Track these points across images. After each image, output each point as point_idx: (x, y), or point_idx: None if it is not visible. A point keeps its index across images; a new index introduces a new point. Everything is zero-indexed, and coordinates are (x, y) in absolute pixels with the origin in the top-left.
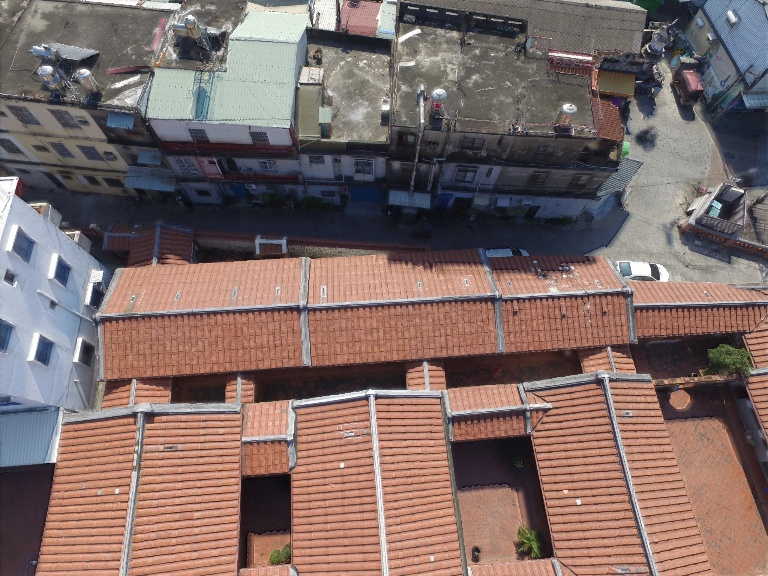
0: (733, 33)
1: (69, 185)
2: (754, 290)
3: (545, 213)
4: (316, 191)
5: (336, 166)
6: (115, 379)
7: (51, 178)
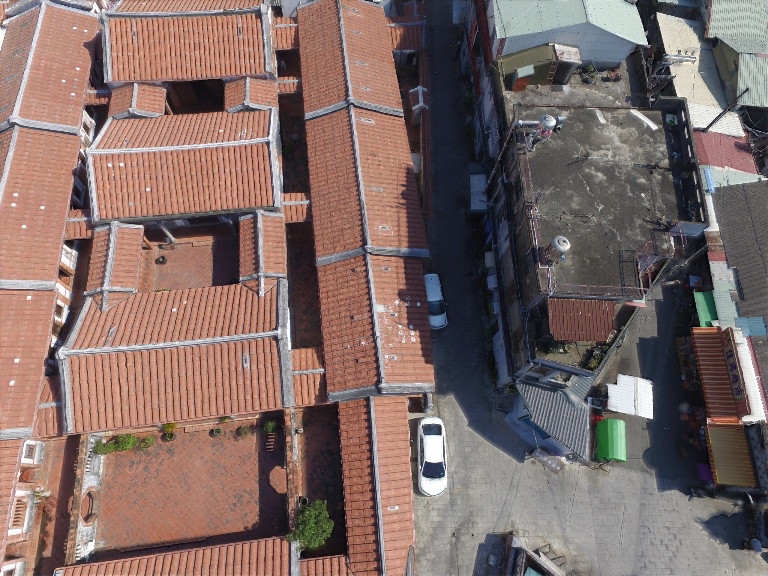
0: None
1: None
2: None
3: None
4: None
5: (495, 117)
6: (298, 15)
7: None
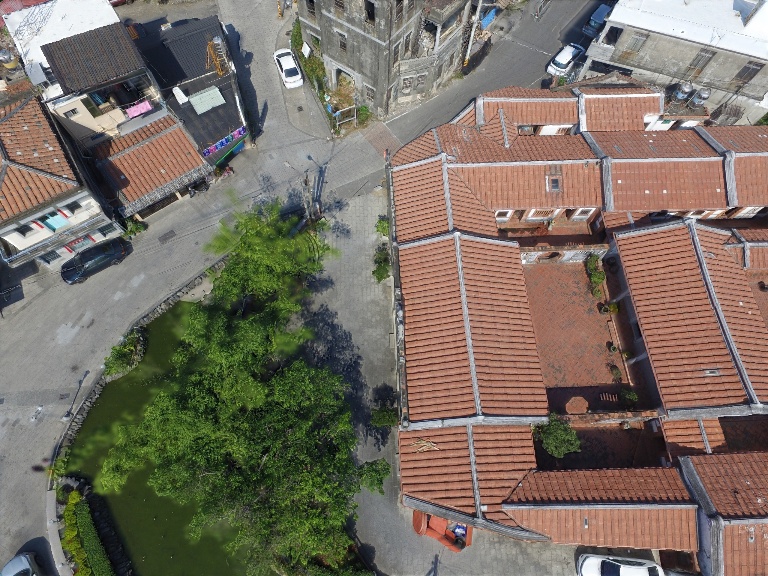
0: None
1: None
2: (523, 528)
3: None
4: None
5: None
6: None
7: None
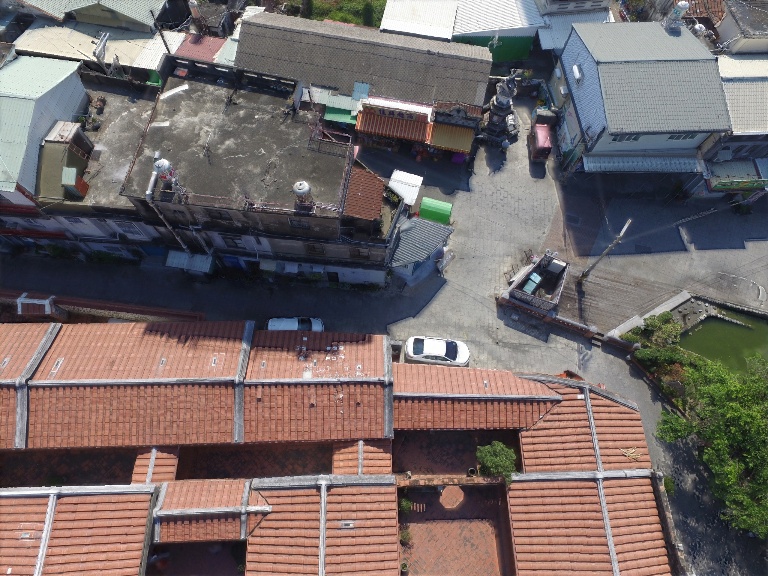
0: (579, 89)
1: None
2: (540, 382)
3: (348, 278)
4: (98, 246)
5: (104, 224)
6: None
7: None
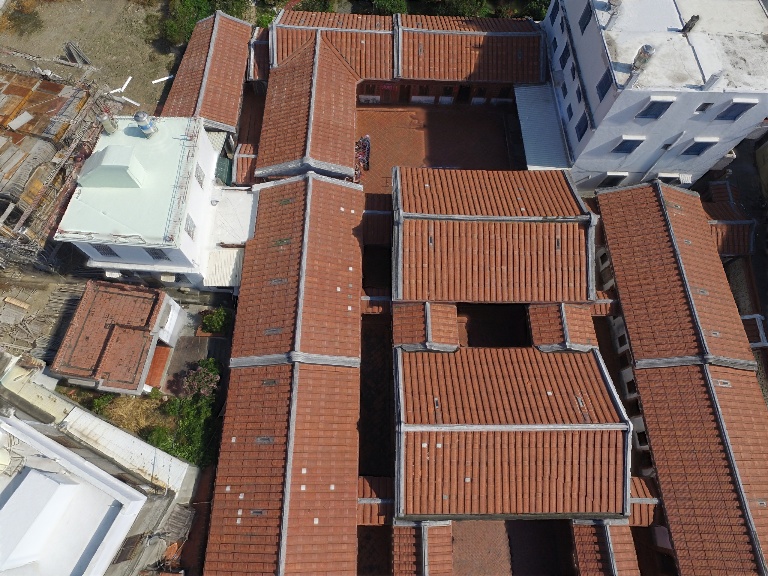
0: None
1: (763, 150)
2: None
3: None
4: None
5: None
6: (599, 202)
7: (767, 135)
